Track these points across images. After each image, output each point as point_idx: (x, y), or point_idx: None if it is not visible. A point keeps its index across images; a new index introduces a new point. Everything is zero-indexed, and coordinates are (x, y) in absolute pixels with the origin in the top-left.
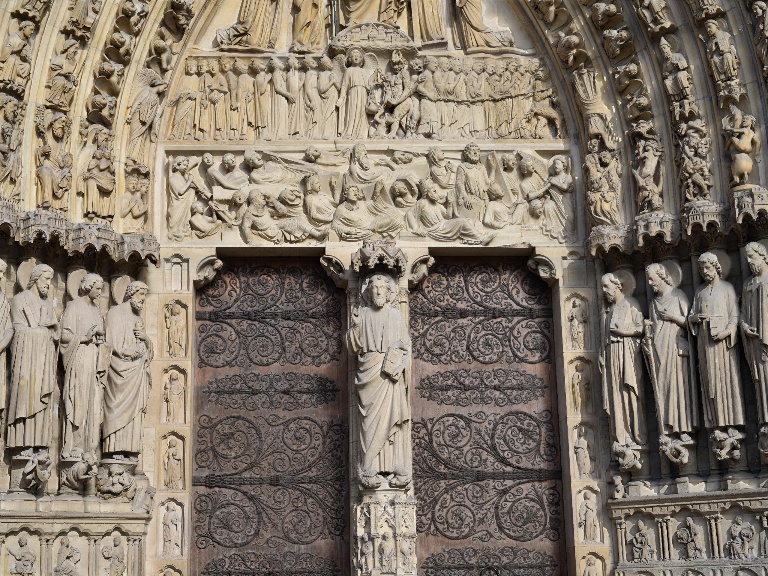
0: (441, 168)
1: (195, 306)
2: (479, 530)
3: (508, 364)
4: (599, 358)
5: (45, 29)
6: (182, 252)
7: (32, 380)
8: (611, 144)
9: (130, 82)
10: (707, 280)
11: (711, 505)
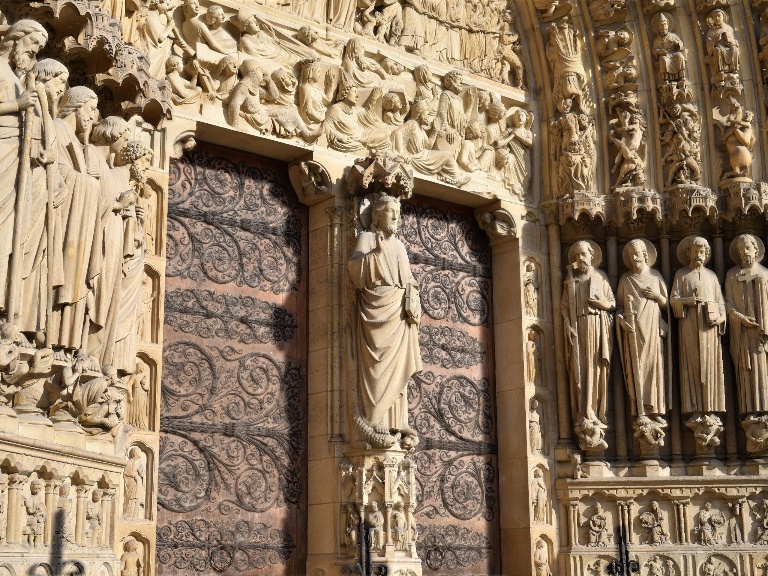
0: (428, 90)
1: None
2: (427, 505)
3: (453, 322)
4: (570, 328)
5: None
6: None
7: (81, 250)
8: (585, 108)
9: None
10: (698, 264)
11: (684, 490)
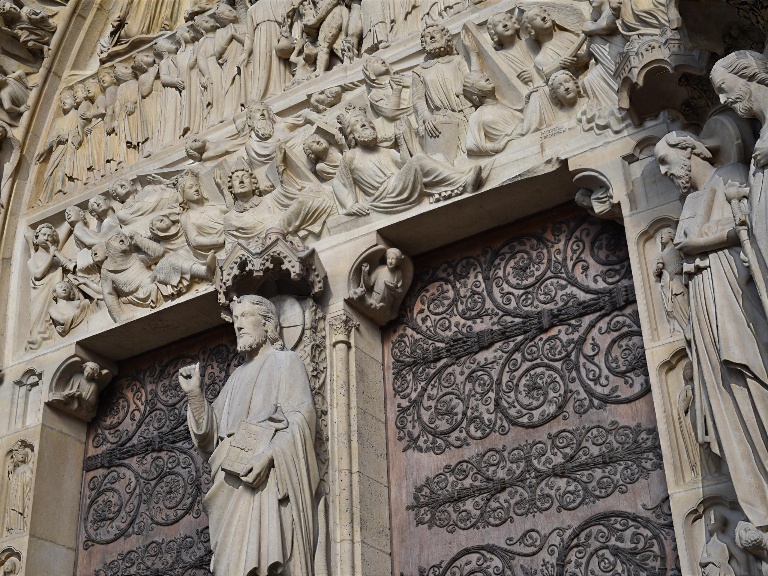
0: (383, 88)
1: (85, 450)
2: None
3: (578, 416)
4: None
5: None
6: (35, 364)
7: None
8: None
9: None
10: None
11: None
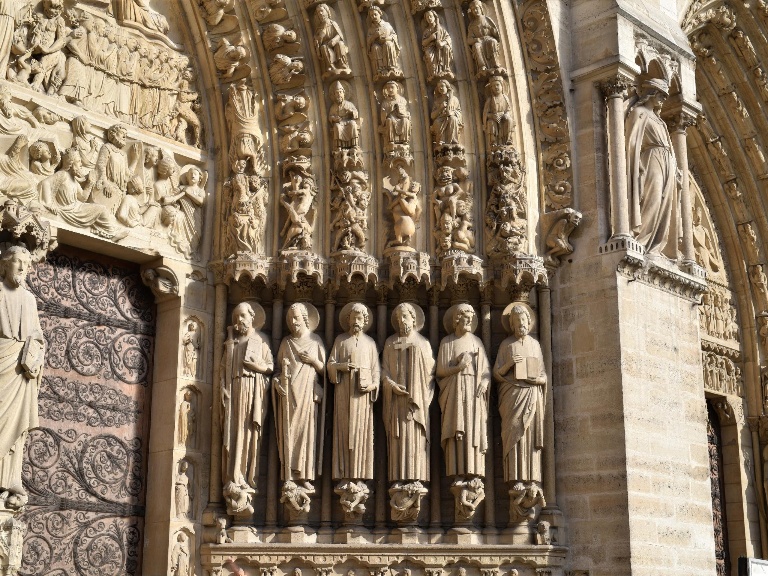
0: (86, 142)
1: None
2: (55, 568)
3: (105, 380)
4: (224, 390)
5: None
6: None
7: None
8: (259, 170)
9: None
10: (355, 330)
11: (327, 557)
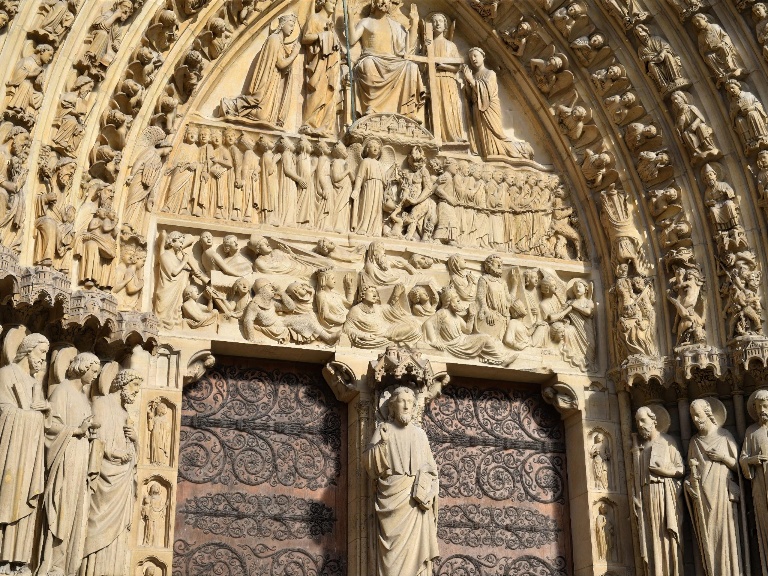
0: (462, 277)
1: None
2: None
3: (520, 502)
4: (634, 499)
5: (57, 59)
6: (172, 342)
7: (20, 476)
8: (642, 270)
9: (133, 138)
10: (764, 420)
11: None
